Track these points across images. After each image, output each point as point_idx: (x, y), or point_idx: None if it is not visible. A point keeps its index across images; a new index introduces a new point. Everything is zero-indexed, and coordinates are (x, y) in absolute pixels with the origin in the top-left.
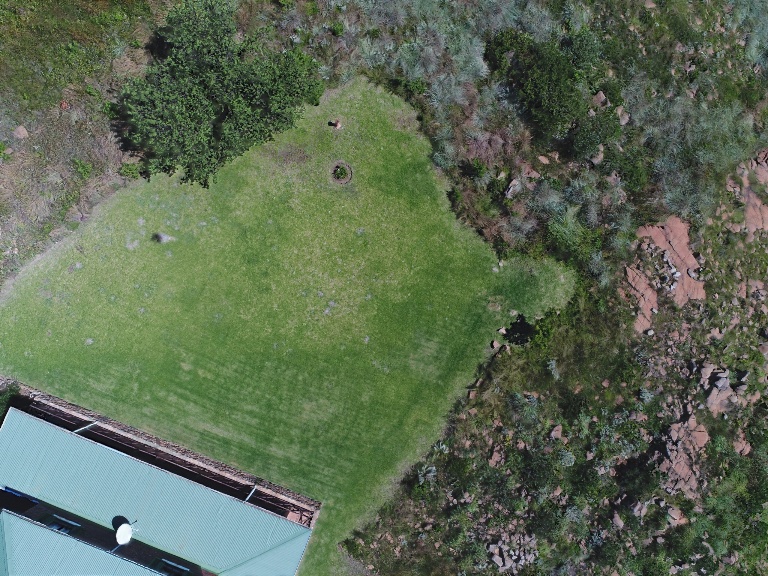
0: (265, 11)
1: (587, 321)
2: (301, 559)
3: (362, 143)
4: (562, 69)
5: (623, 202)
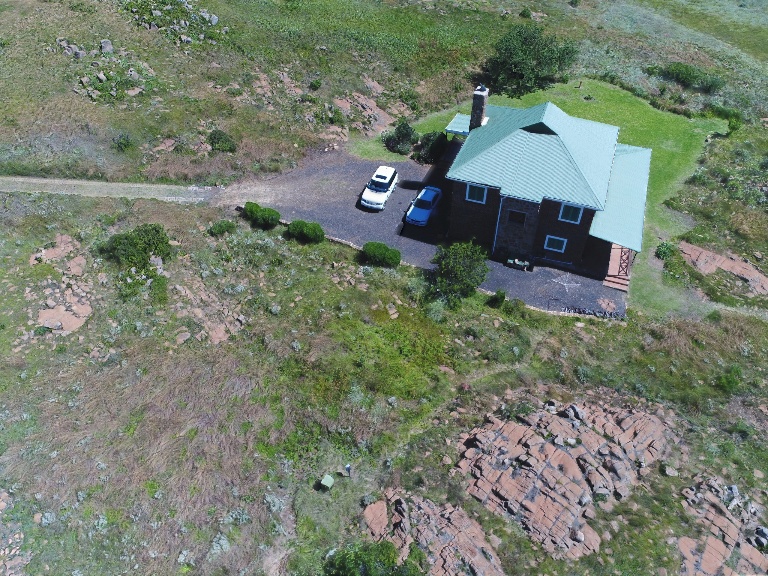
0: None
1: None
2: None
3: None
4: None
5: None
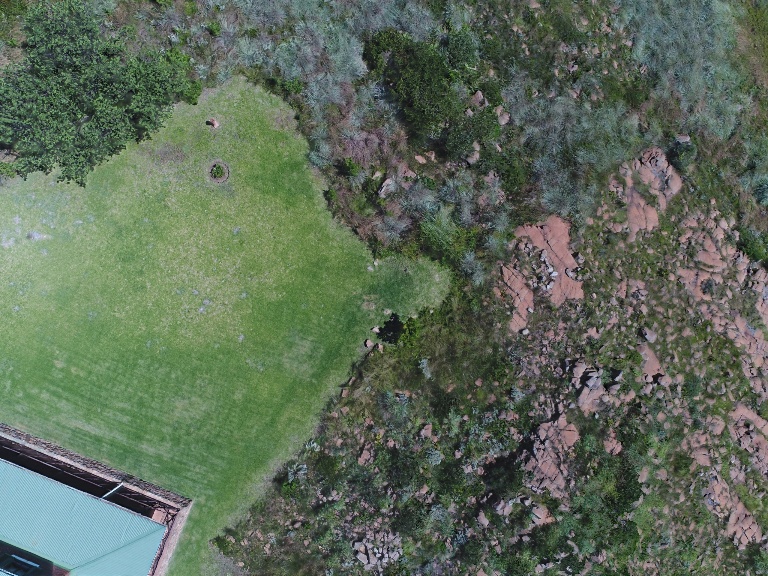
0: (143, 10)
1: (460, 320)
2: (172, 556)
3: (240, 142)
4: (435, 69)
5: (502, 202)
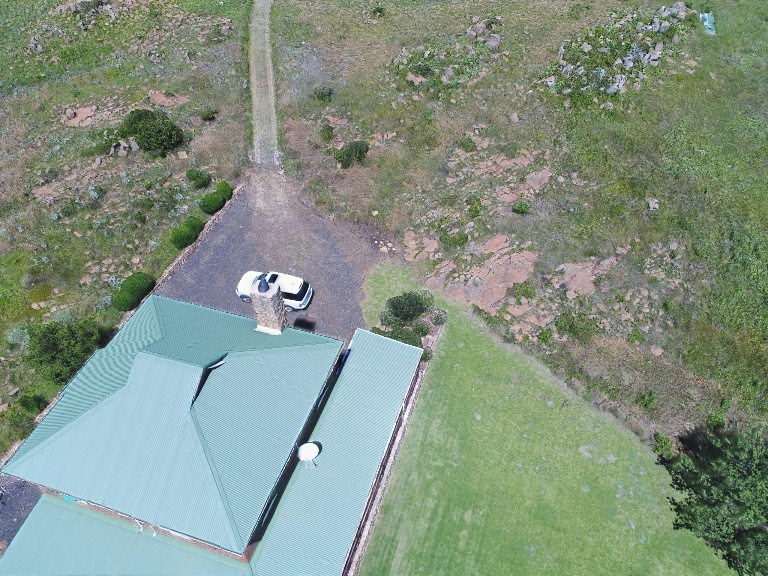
0: None
1: None
2: None
3: None
4: None
5: None
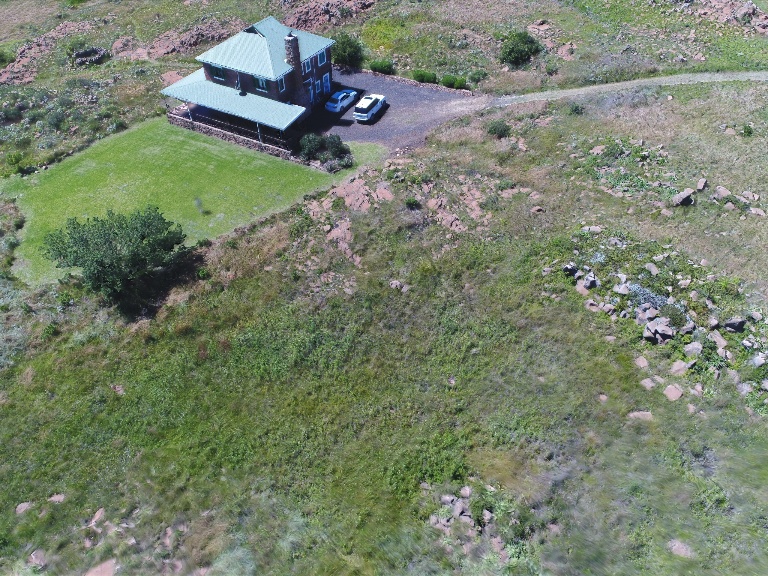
0: None
1: None
2: None
3: None
4: None
5: None
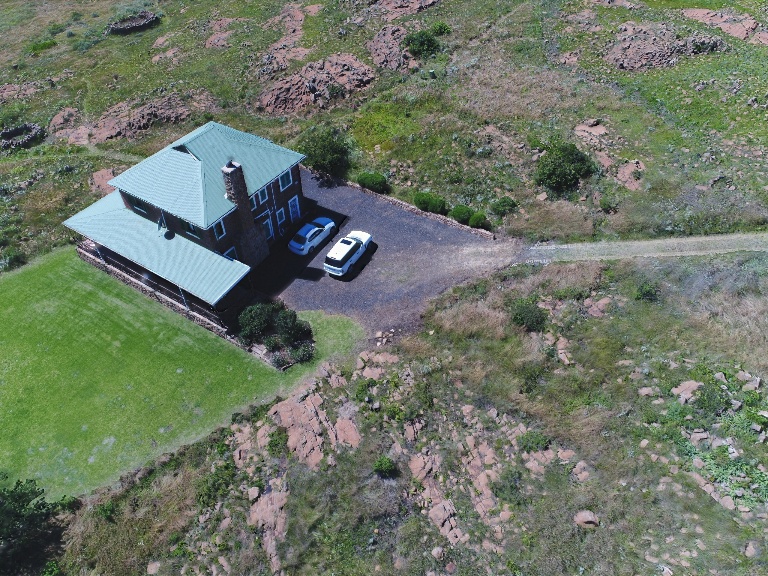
0: None
1: None
2: None
3: None
4: None
5: None
